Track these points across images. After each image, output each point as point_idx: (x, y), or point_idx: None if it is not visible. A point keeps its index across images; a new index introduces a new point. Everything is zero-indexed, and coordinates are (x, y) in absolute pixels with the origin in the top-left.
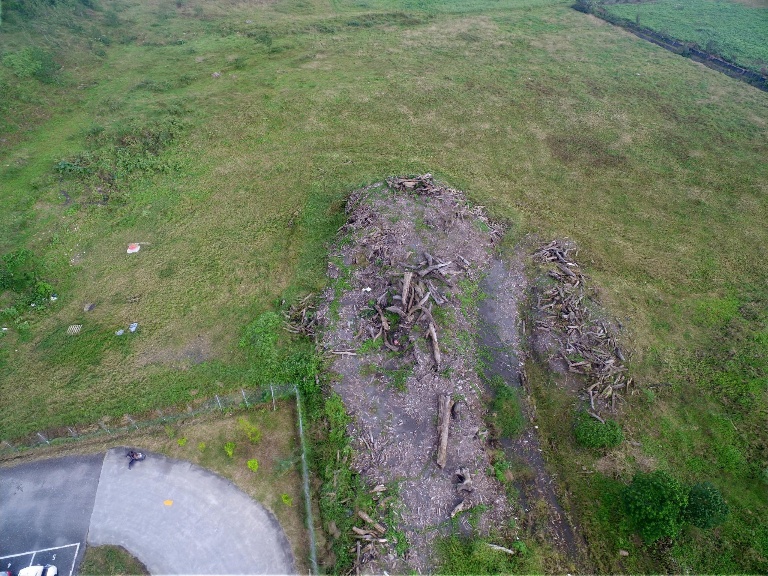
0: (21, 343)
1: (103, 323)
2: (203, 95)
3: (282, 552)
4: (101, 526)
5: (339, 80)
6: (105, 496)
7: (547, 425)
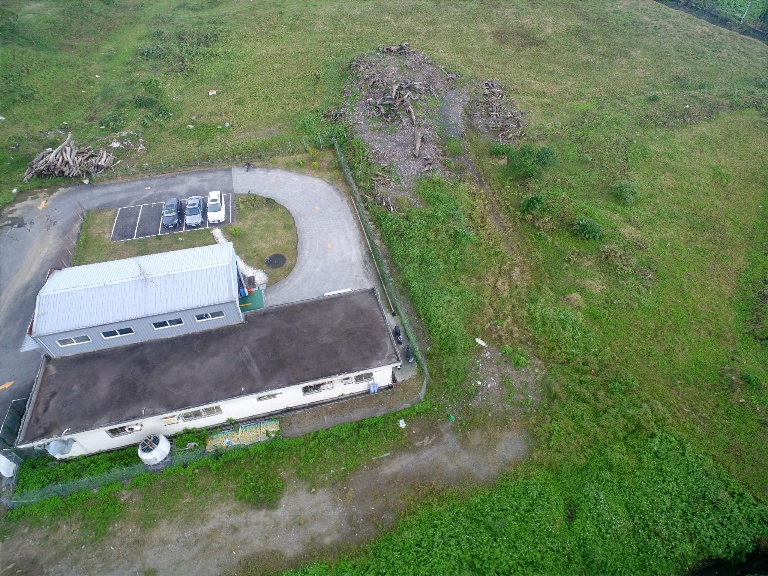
0: (161, 131)
1: (207, 123)
2: (230, 12)
3: (336, 192)
4: (240, 188)
5: (335, 1)
6: (238, 180)
7: (475, 152)
